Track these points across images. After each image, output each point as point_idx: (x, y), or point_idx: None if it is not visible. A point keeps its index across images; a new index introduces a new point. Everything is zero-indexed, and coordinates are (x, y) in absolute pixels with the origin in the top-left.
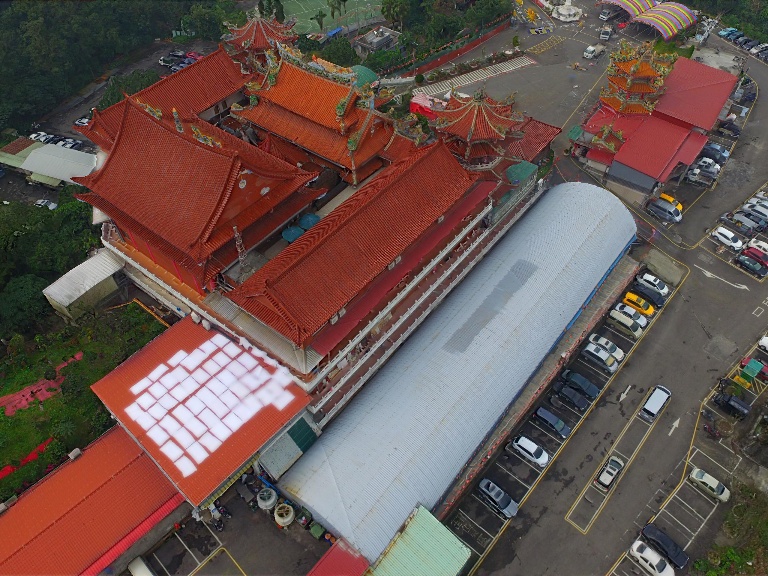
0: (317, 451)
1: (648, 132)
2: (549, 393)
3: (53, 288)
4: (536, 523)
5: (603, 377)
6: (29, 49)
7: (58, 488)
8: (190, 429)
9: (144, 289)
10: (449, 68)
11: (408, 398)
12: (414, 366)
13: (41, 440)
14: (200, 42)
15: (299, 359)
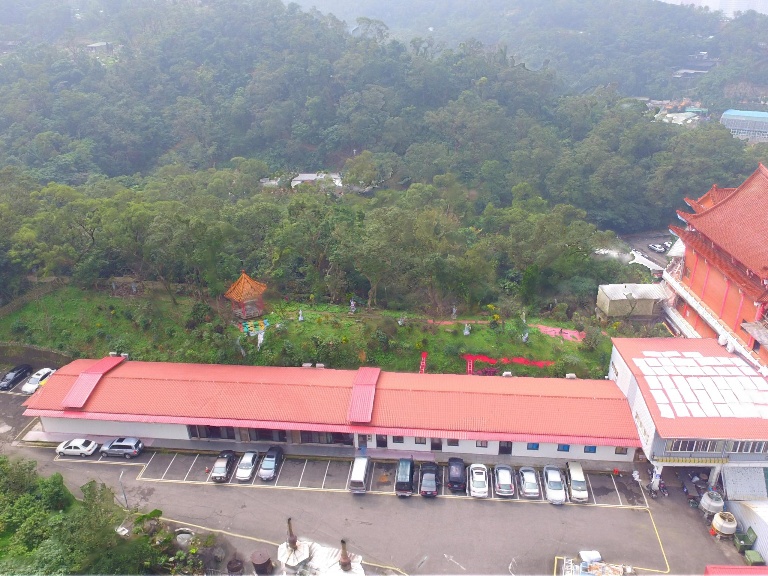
0: None
1: None
2: None
3: (608, 287)
4: None
5: None
6: (649, 183)
7: (551, 384)
8: (682, 393)
9: (673, 323)
10: None
11: None
12: None
13: (552, 358)
14: None
15: None
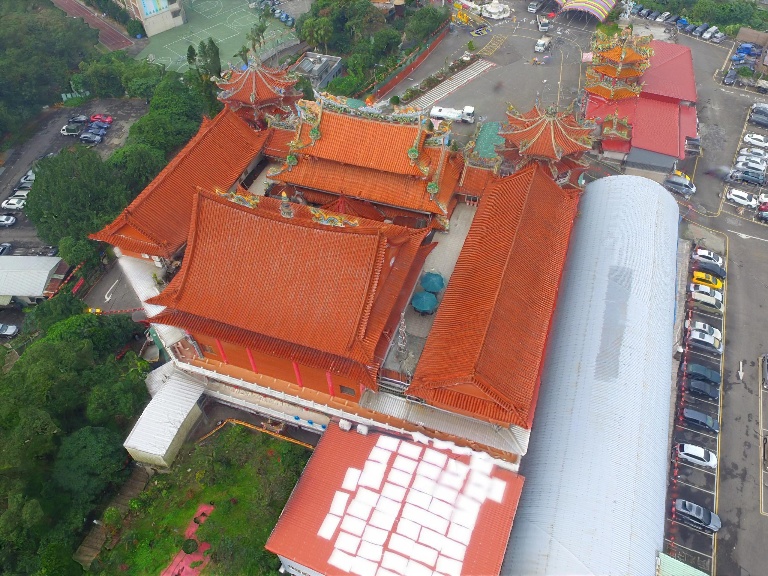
0: (530, 531)
1: (646, 114)
2: (678, 391)
3: (135, 437)
4: (740, 527)
5: (714, 360)
6: None
7: None
8: (419, 559)
9: (235, 405)
10: (418, 84)
11: (595, 443)
12: (578, 406)
13: None
14: (98, 101)
15: (508, 440)
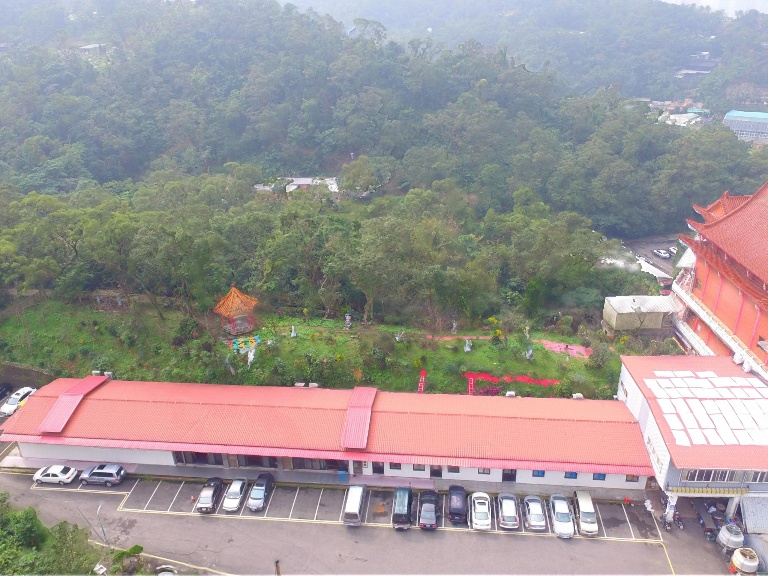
0: None
1: None
2: None
3: (615, 299)
4: None
5: None
6: (653, 187)
7: (557, 405)
8: (698, 418)
9: (683, 338)
10: None
11: None
12: None
13: (557, 376)
14: None
15: None
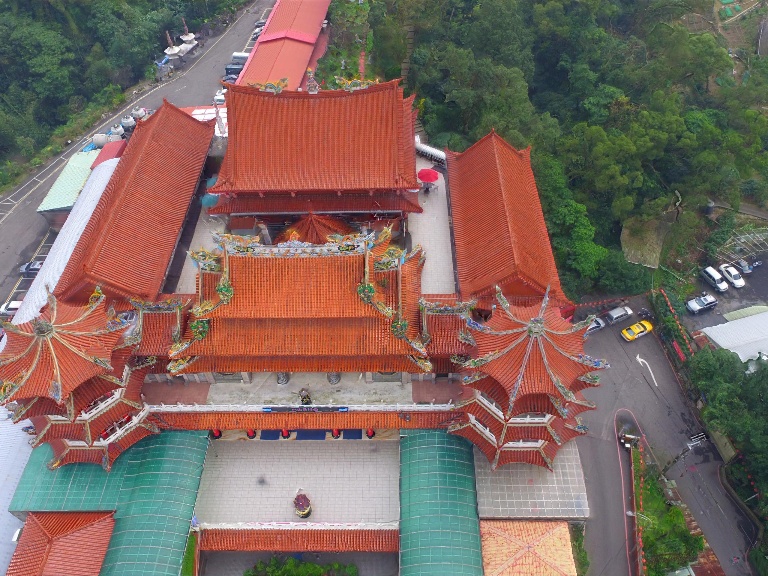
0: None
1: None
2: None
3: (416, 139)
4: (8, 275)
5: None
6: None
7: None
8: None
9: None
10: None
11: None
12: None
13: None
14: None
15: None
